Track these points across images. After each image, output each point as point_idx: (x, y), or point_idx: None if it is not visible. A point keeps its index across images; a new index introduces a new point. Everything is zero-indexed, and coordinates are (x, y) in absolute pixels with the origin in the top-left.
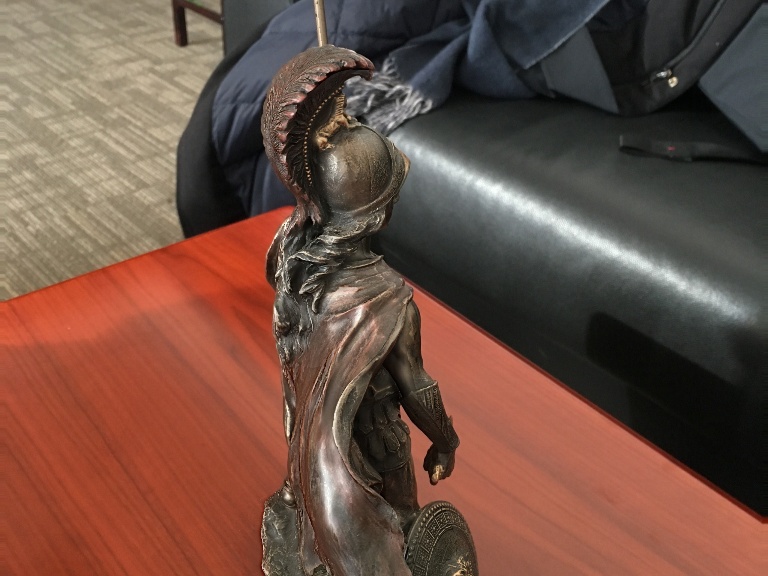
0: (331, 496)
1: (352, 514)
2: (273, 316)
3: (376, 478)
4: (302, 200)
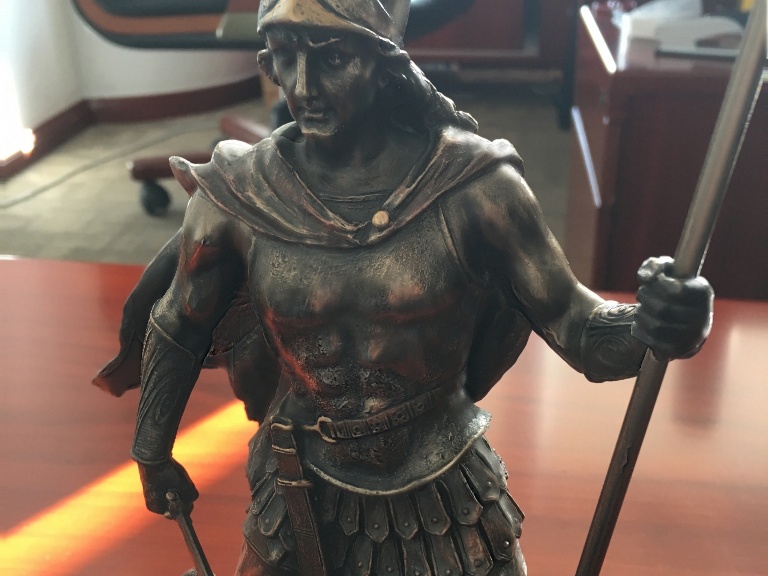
0: None
1: None
2: None
3: (252, 463)
4: None
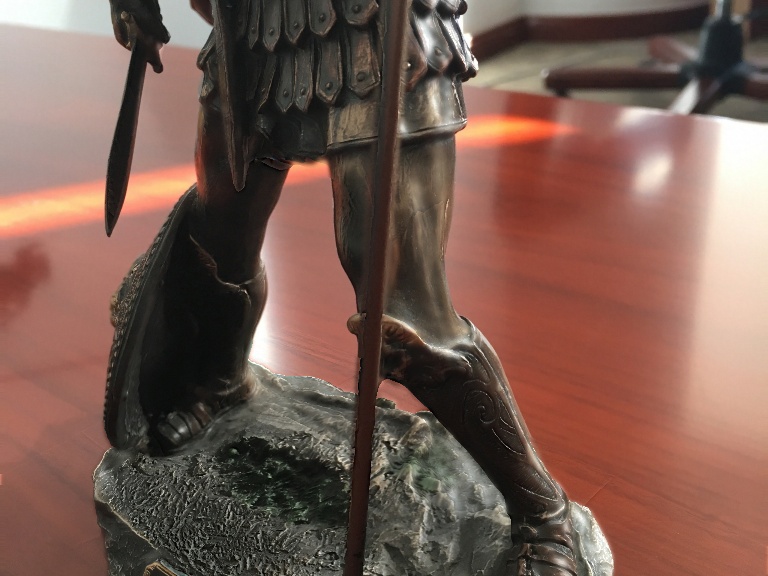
0: None
1: None
2: None
3: None
4: None
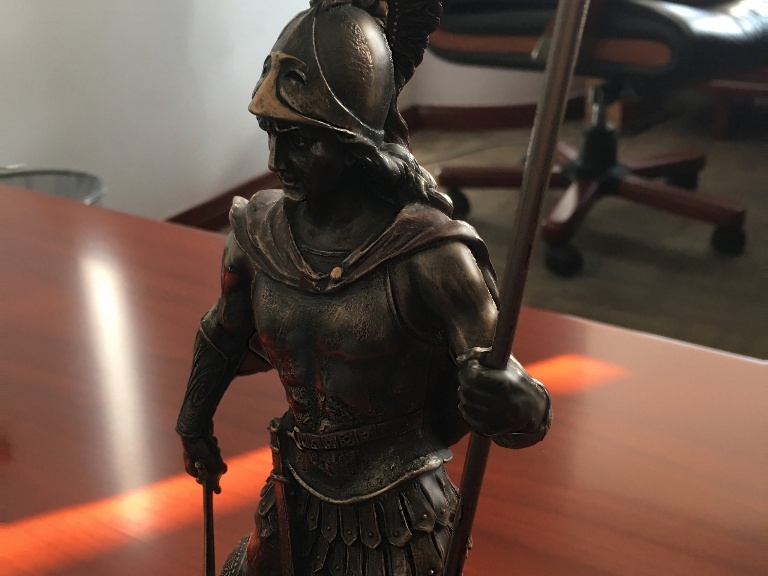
0: None
1: None
2: None
3: None
4: None
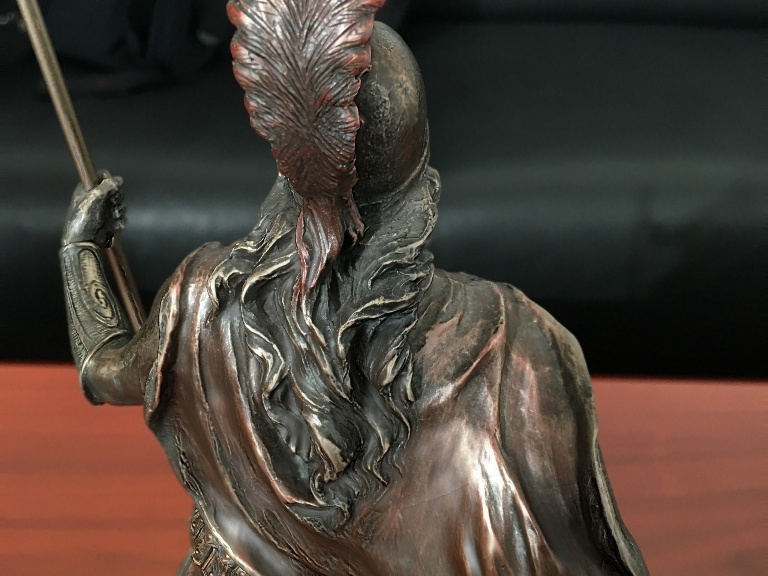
0: None
1: None
2: (267, 466)
3: None
4: (338, 202)
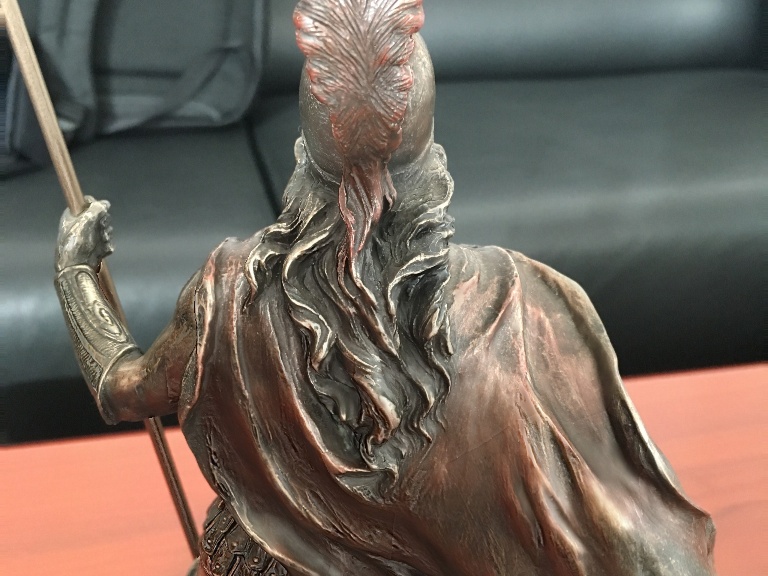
0: (685, 568)
1: (707, 567)
2: (317, 439)
3: None
4: None
